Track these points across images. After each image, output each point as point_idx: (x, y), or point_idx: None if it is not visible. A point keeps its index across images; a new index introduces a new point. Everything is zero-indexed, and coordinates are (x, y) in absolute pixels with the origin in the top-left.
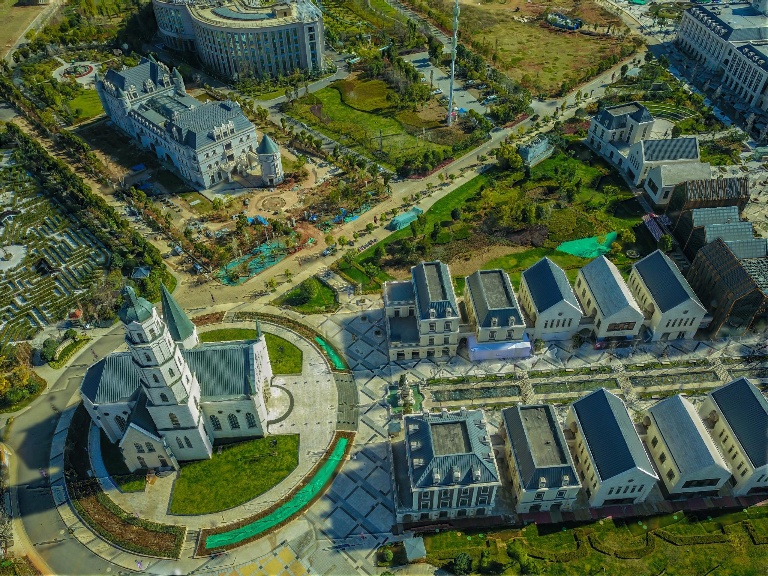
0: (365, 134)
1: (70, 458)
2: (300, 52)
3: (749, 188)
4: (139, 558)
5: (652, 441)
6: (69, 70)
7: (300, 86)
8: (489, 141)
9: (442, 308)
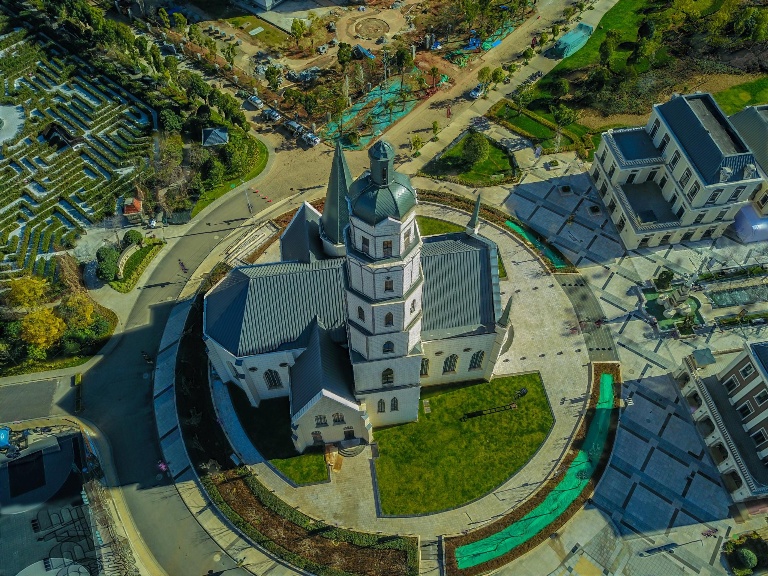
0: None
1: (193, 435)
2: None
3: None
4: None
5: None
6: None
7: None
8: None
9: (740, 165)
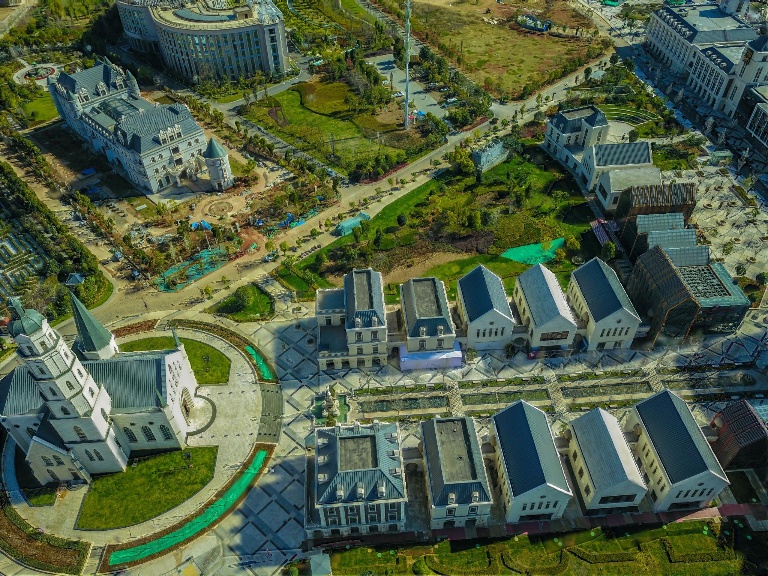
0: (320, 138)
1: None
2: (262, 54)
3: (695, 194)
4: (40, 575)
5: (573, 455)
6: (31, 72)
7: (261, 89)
8: (445, 145)
9: (368, 317)
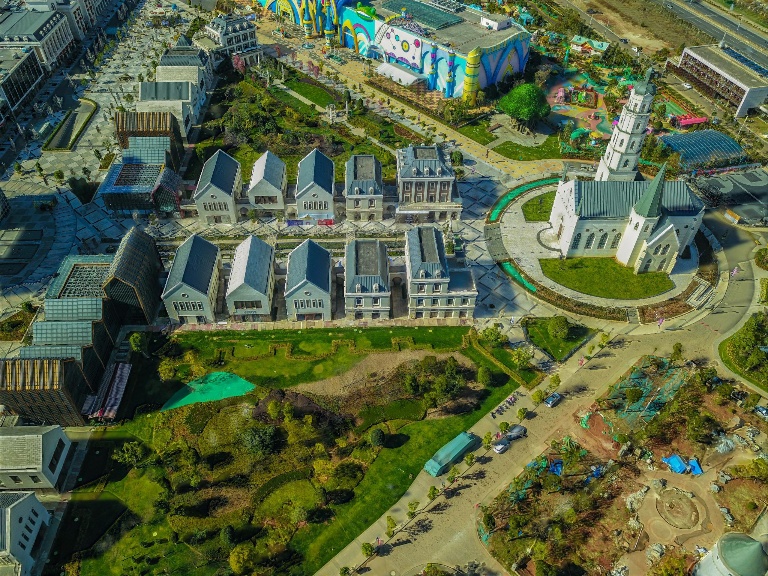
0: None
1: None
2: None
3: None
4: None
5: None
6: None
7: None
8: None
9: None
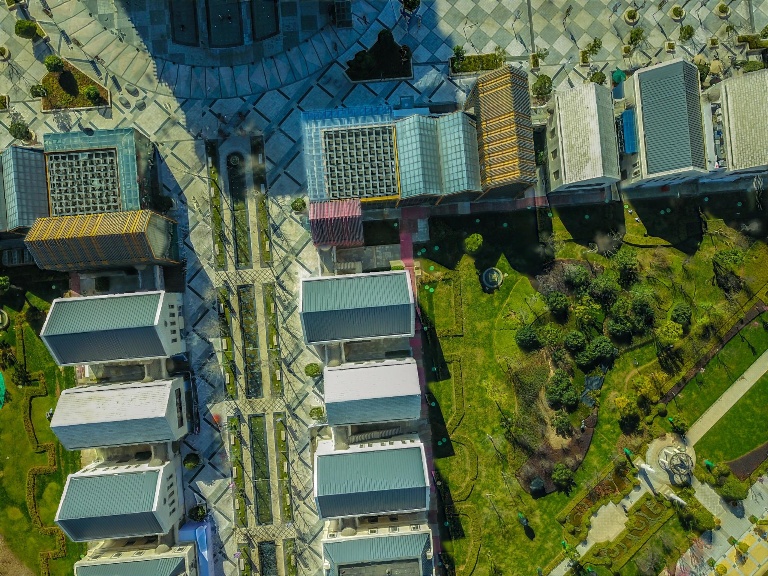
0: None
1: None
2: None
3: None
4: None
5: None
6: None
7: None
8: None
9: None
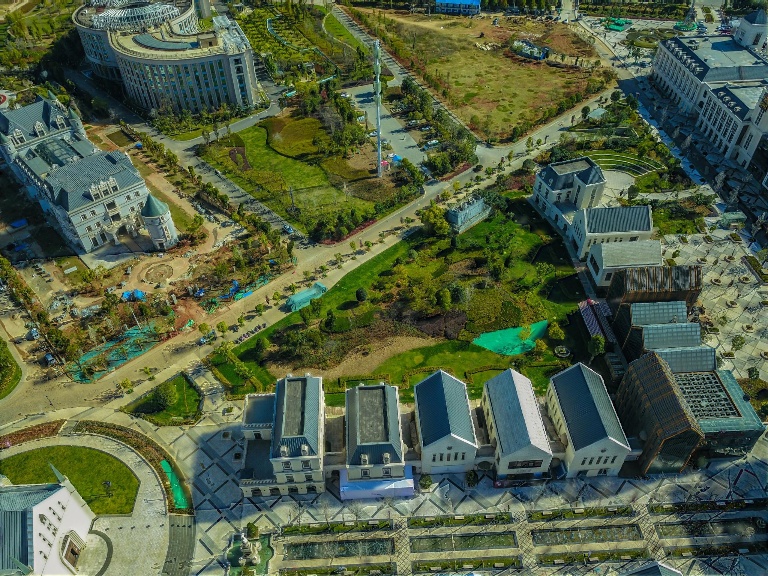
0: (281, 186)
1: None
2: (228, 85)
3: (701, 278)
4: None
5: None
6: None
7: (224, 124)
8: (421, 197)
9: (296, 445)
